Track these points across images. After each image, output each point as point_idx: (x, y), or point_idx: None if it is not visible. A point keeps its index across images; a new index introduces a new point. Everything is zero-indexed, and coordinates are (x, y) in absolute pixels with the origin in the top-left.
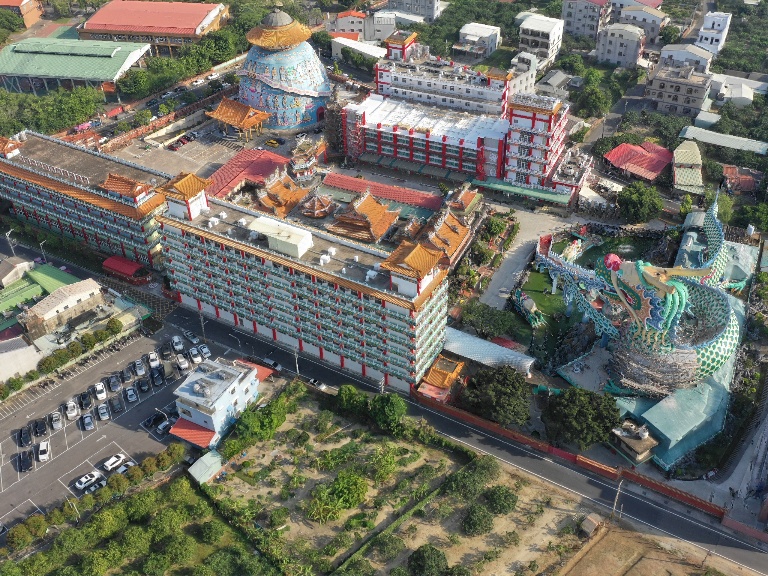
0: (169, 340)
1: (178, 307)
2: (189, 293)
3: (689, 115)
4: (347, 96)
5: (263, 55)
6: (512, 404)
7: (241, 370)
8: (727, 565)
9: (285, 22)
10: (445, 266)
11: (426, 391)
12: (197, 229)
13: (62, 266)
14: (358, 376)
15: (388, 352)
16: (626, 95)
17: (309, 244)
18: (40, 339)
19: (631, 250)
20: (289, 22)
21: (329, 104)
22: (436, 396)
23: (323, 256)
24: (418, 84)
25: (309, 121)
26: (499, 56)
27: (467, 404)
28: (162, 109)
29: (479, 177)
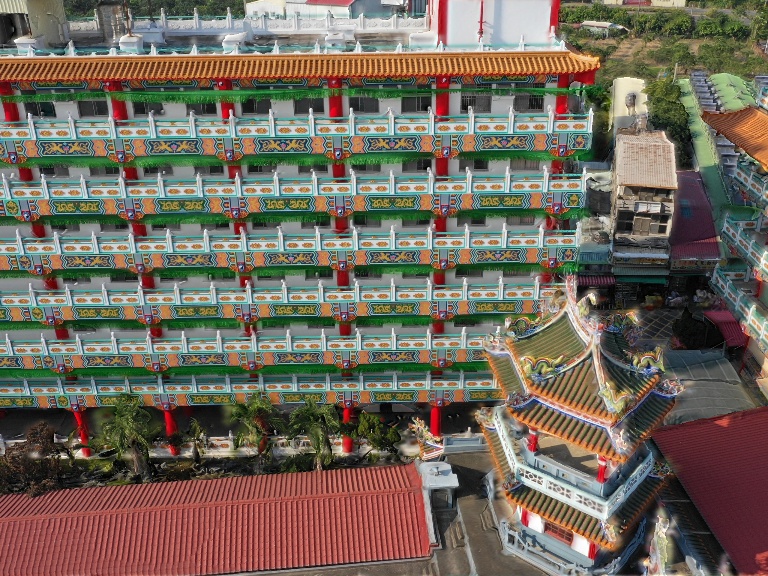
0: None
1: None
2: None
3: None
4: None
5: None
6: None
7: None
8: None
9: None
10: None
11: None
12: None
13: None
14: None
15: None
16: None
17: None
18: (609, 176)
19: None
20: None
21: None
22: None
23: None
24: None
25: None
26: None
27: None
28: None
29: None
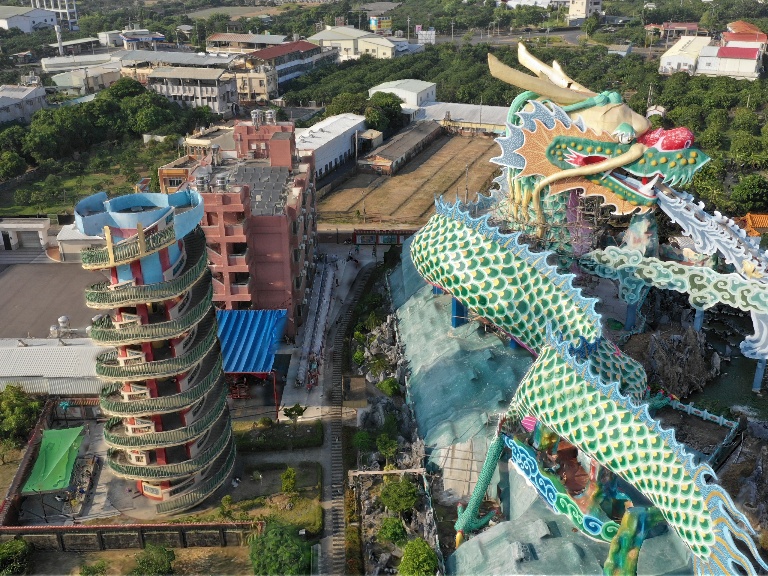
0: None
1: None
2: None
3: None
4: None
5: None
6: None
7: None
8: (343, 228)
9: None
10: None
11: None
12: None
13: None
14: None
15: None
16: None
17: None
18: None
19: None
20: None
21: None
22: None
23: None
24: None
25: None
26: None
27: None
28: None
29: None
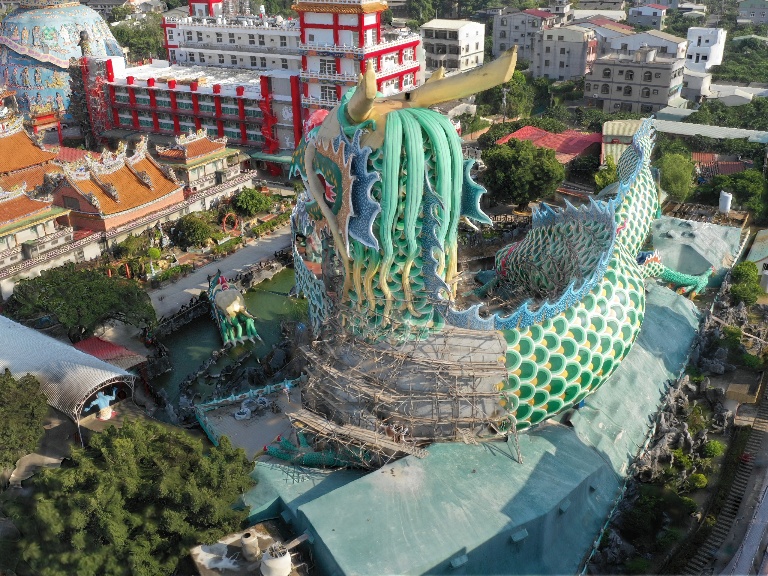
0: None
1: None
2: None
3: None
4: None
5: (16, 13)
6: None
7: None
8: None
9: None
10: None
11: None
12: None
13: None
14: None
15: None
16: (563, 105)
17: None
18: None
19: None
20: None
21: (76, 62)
22: None
23: None
24: (218, 41)
25: None
26: None
27: None
28: None
29: (268, 150)
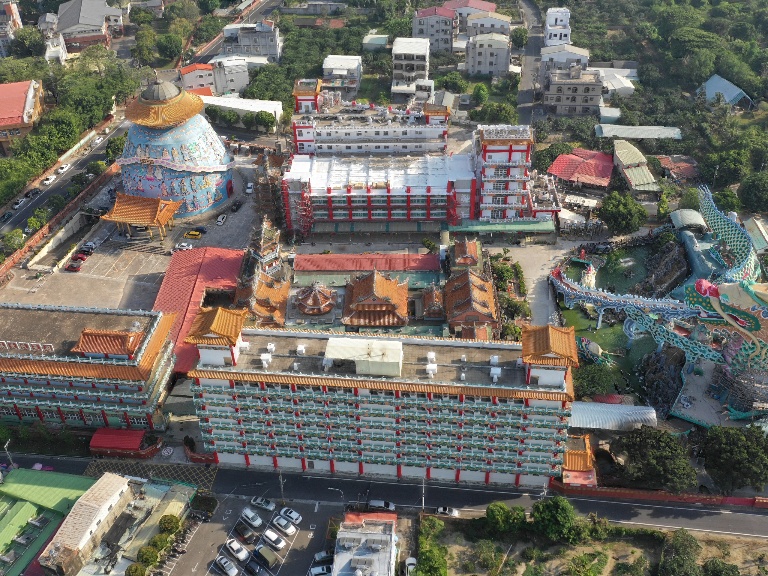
0: (236, 517)
1: (218, 470)
2: (235, 450)
3: (588, 113)
4: (239, 161)
5: (154, 136)
6: (681, 467)
7: (376, 529)
8: None
9: (173, 93)
10: (493, 331)
11: (573, 480)
12: (253, 374)
13: (35, 464)
14: (481, 486)
15: (527, 452)
16: None
17: (401, 356)
18: None
19: (633, 262)
20: (177, 92)
21: (259, 177)
22: (587, 482)
23: (429, 366)
24: (346, 135)
25: (220, 199)
26: (369, 86)
27: (628, 481)
28: (32, 224)
29: (452, 222)
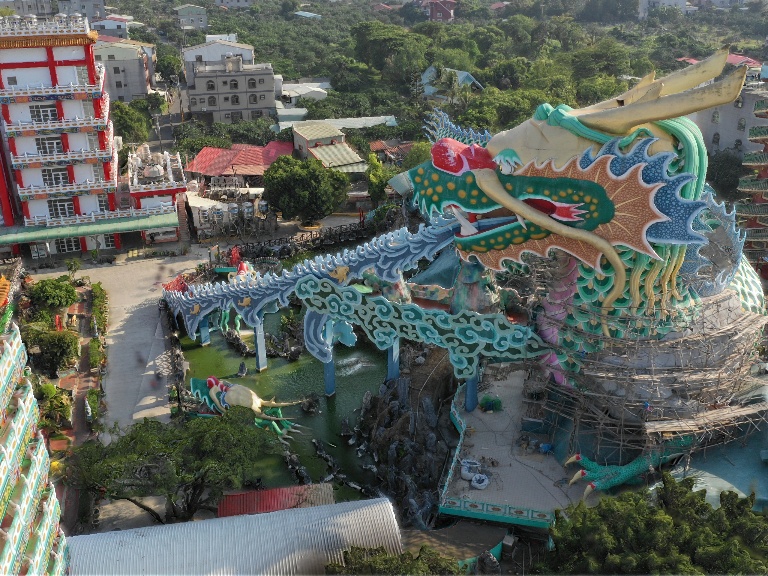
0: None
1: None
2: None
3: None
4: None
5: None
6: None
7: None
8: None
9: None
10: None
11: None
12: None
13: None
14: None
15: None
16: None
17: None
18: None
19: None
20: None
21: None
22: None
23: None
24: None
25: None
26: None
27: None
28: None
29: None
